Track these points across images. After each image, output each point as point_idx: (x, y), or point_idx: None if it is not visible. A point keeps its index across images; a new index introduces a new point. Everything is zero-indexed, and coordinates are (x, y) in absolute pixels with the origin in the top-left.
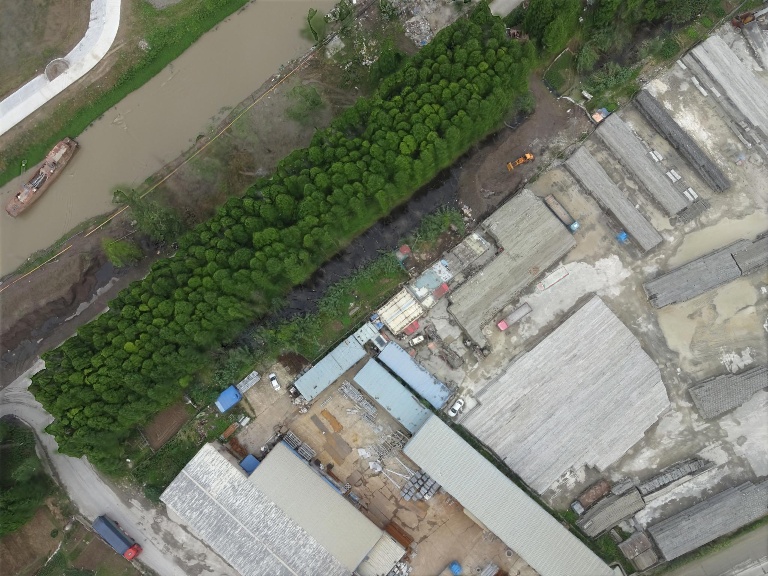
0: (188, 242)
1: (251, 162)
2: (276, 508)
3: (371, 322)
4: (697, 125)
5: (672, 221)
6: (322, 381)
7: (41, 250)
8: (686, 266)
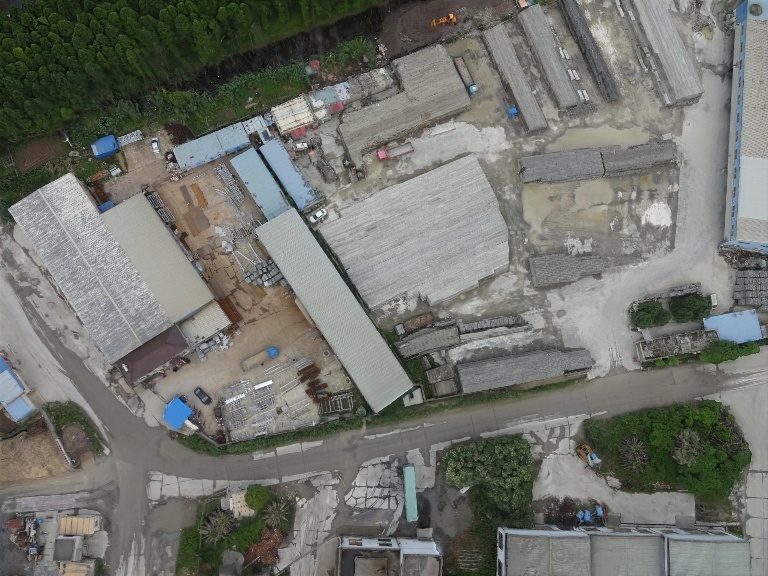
0: None
1: None
2: (119, 248)
3: (263, 117)
4: (607, 39)
5: (560, 113)
6: (200, 154)
7: None
8: (559, 151)
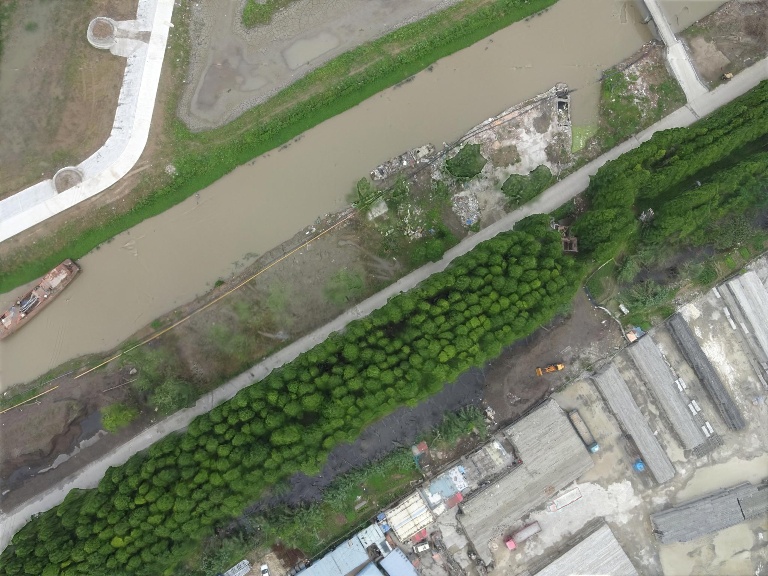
0: (200, 431)
1: (272, 323)
2: None
3: (377, 523)
4: (722, 358)
5: (686, 453)
6: None
7: (20, 384)
8: (695, 506)
